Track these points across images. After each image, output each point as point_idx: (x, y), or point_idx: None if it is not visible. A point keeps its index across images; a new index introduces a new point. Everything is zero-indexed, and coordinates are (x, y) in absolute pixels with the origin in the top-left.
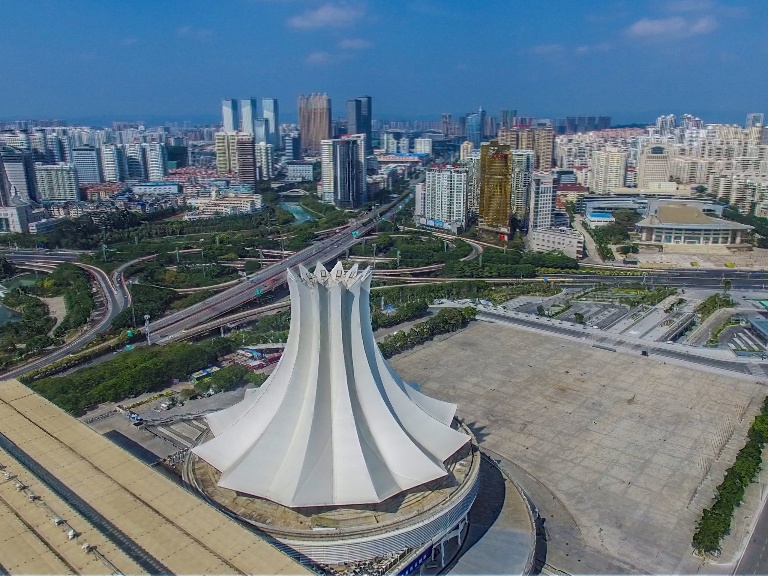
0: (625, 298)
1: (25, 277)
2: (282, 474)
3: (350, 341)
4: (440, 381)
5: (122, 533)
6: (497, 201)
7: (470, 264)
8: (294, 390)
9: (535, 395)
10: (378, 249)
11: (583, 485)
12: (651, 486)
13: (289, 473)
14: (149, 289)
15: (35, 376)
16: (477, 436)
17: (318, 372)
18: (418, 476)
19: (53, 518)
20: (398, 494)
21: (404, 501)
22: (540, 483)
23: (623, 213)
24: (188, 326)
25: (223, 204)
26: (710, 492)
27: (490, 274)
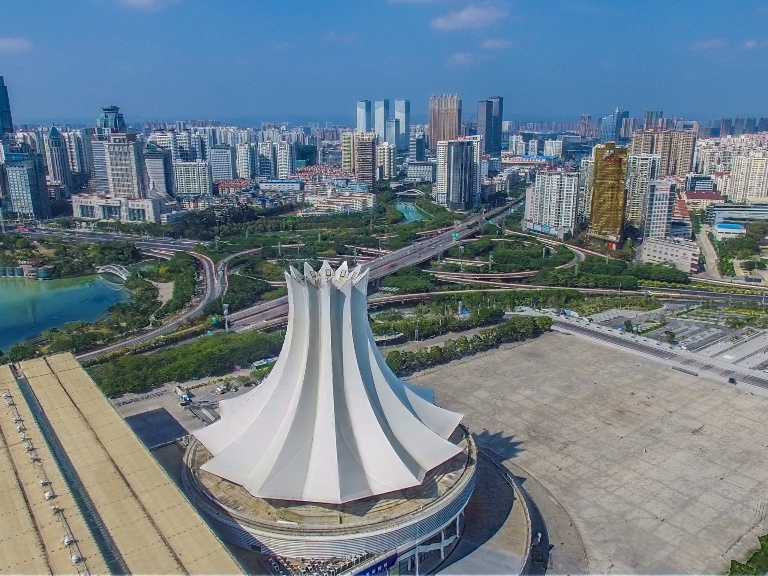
0: (733, 318)
1: (149, 263)
2: (261, 464)
3: (341, 341)
4: (491, 390)
5: (90, 500)
6: (607, 207)
7: (565, 272)
8: (285, 384)
9: (588, 414)
10: (476, 252)
11: (609, 515)
12: (687, 526)
13: (265, 464)
14: (245, 280)
15: (126, 353)
16: (510, 451)
17: (306, 369)
18: (392, 482)
19: (42, 479)
20: (370, 498)
21: (375, 506)
22: (561, 507)
23: (758, 225)
24: (270, 317)
25: (336, 202)
26: (756, 542)
27: (586, 284)
